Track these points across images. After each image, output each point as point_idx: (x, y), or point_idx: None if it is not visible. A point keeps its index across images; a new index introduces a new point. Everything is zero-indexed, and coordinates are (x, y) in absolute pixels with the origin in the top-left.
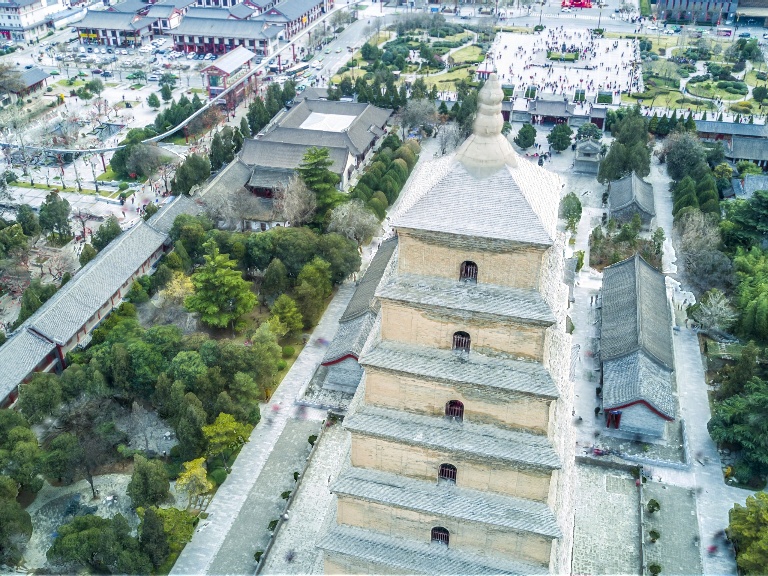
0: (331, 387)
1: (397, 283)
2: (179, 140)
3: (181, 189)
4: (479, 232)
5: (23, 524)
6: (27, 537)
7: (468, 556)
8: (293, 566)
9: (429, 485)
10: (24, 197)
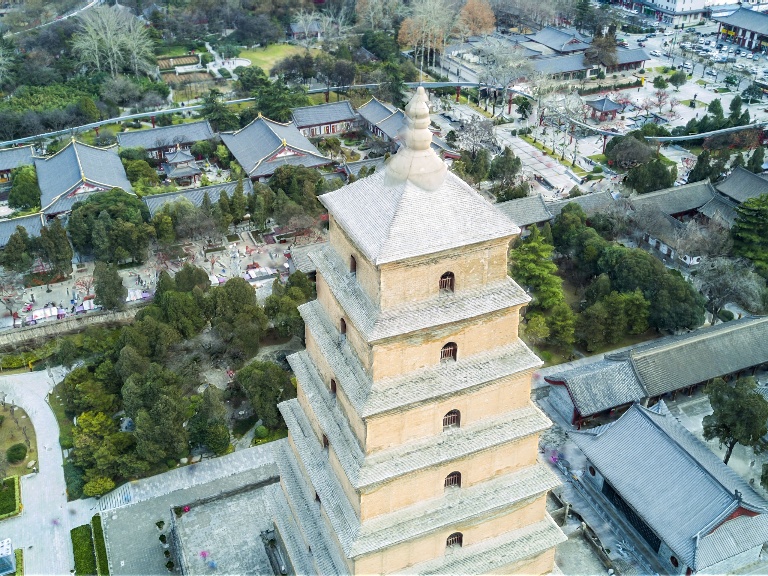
0: (544, 404)
1: (323, 252)
2: (698, 150)
3: (627, 188)
4: (349, 229)
5: (248, 347)
6: (245, 356)
7: (326, 531)
8: None
9: (319, 447)
10: (517, 149)
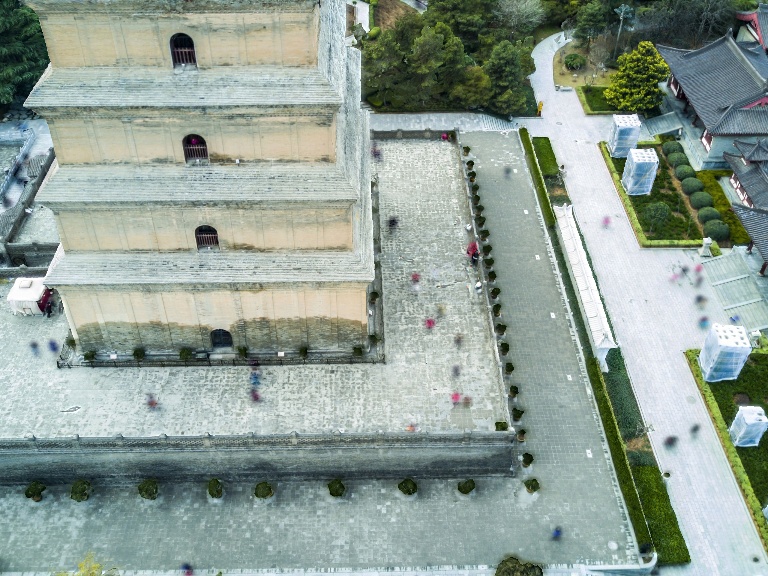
0: None
1: None
2: None
3: None
4: None
5: None
6: None
7: None
8: (250, 408)
9: (323, 26)
10: None
